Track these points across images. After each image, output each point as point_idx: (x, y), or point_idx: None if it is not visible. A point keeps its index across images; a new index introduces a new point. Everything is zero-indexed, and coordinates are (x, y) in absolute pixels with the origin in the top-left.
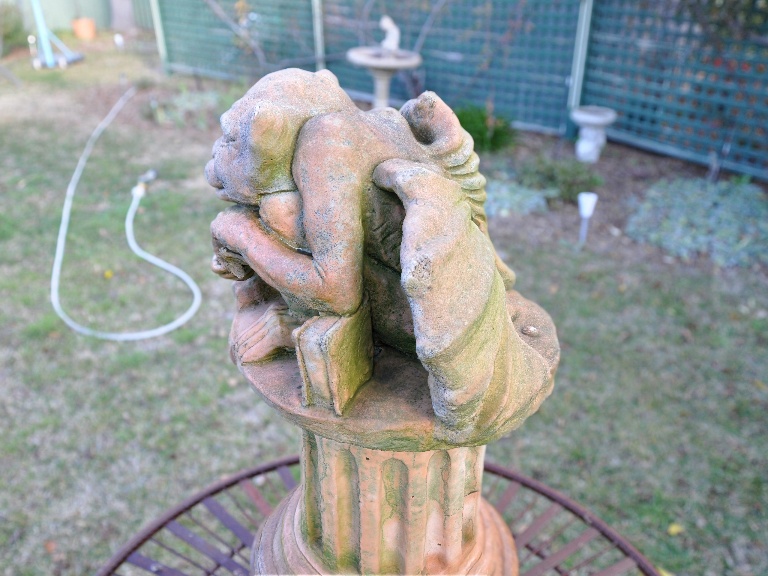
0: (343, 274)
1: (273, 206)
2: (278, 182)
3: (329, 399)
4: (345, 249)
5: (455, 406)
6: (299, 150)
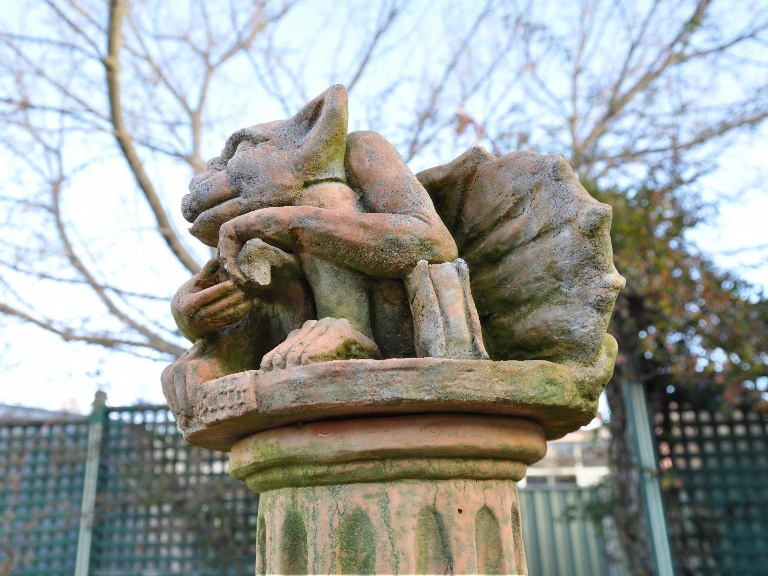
0: (442, 223)
1: (326, 190)
2: (334, 167)
3: (469, 342)
4: (433, 206)
5: (614, 291)
6: (358, 140)
